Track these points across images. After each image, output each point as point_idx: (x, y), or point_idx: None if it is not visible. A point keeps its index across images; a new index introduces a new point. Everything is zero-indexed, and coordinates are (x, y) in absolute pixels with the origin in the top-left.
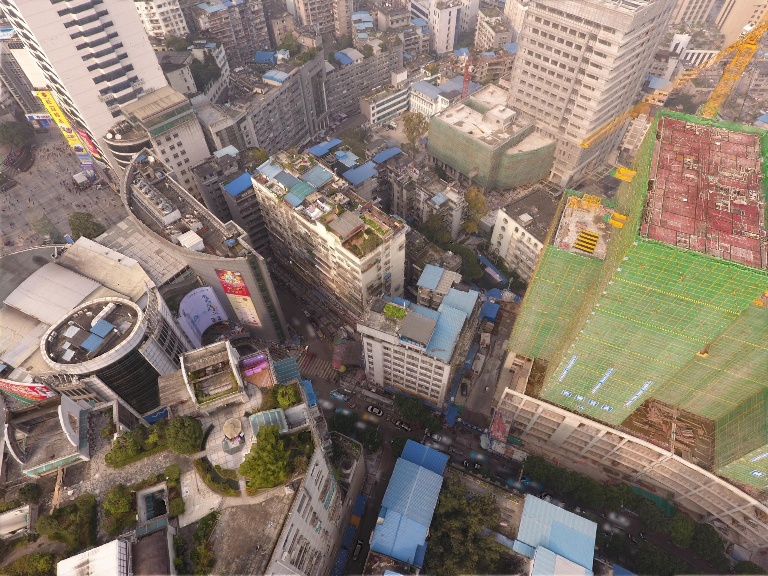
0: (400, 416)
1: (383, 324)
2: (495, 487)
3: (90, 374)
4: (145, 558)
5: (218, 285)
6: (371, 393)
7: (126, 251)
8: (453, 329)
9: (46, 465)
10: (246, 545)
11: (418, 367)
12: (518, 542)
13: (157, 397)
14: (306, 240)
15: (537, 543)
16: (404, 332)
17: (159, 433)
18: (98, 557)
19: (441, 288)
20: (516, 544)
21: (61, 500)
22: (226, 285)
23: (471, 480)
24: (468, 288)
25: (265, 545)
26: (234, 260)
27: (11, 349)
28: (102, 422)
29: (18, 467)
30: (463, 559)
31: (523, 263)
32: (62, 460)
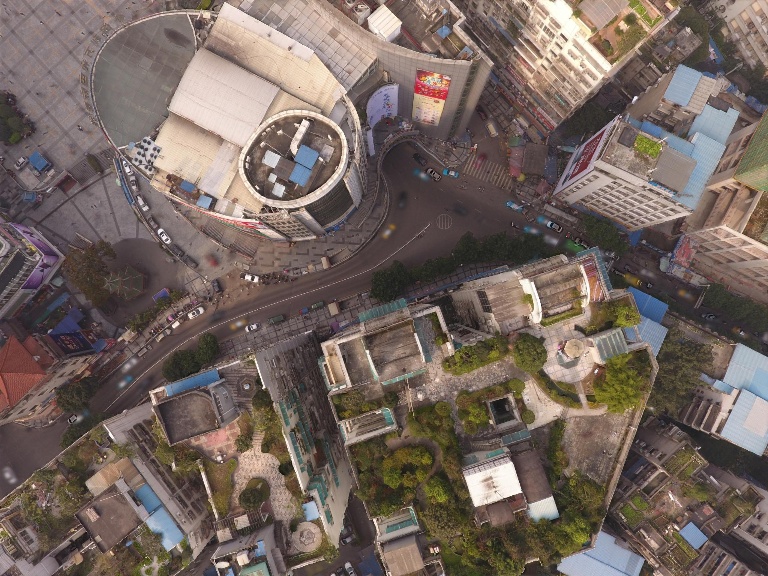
0: (579, 233)
1: (632, 163)
2: (704, 332)
3: (299, 207)
4: (529, 470)
5: (408, 84)
6: (554, 209)
7: (289, 30)
8: (706, 168)
9: (399, 377)
10: (594, 449)
11: (643, 204)
12: (720, 381)
13: (340, 212)
14: (517, 13)
15: (740, 386)
16: (658, 176)
17: (500, 350)
18: (499, 475)
19: (694, 104)
20: (717, 383)
21: (411, 400)
22: (421, 86)
23: (682, 325)
24: (726, 105)
25: (611, 450)
26: (454, 64)
27: (205, 176)
28: (425, 326)
29: (357, 367)
30: (669, 393)
31: (756, 36)
32: (413, 373)
